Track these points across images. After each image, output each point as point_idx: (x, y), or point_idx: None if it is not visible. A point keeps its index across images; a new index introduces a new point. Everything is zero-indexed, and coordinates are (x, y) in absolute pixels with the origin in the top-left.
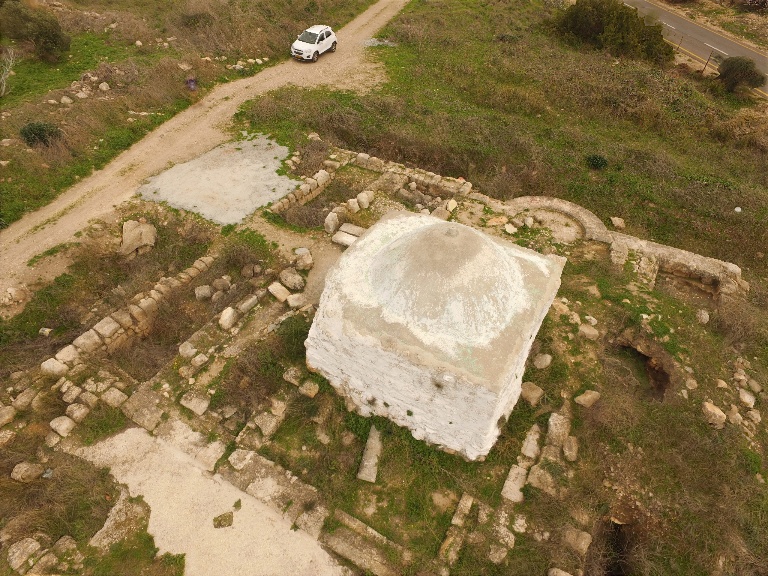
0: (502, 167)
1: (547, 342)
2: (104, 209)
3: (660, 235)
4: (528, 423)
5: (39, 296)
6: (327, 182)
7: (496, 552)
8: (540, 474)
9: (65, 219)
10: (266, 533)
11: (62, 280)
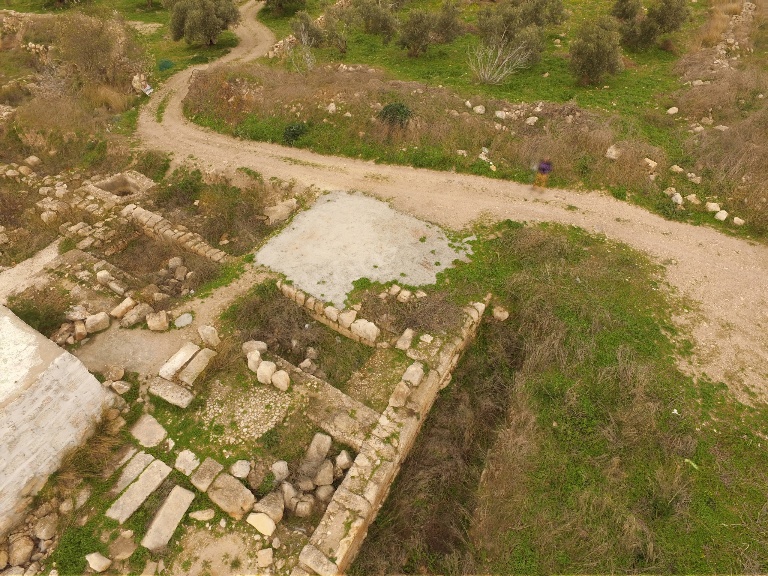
0: None
1: None
2: (308, 181)
3: None
4: None
5: None
6: (367, 340)
7: None
8: None
9: (297, 167)
10: None
11: (232, 190)
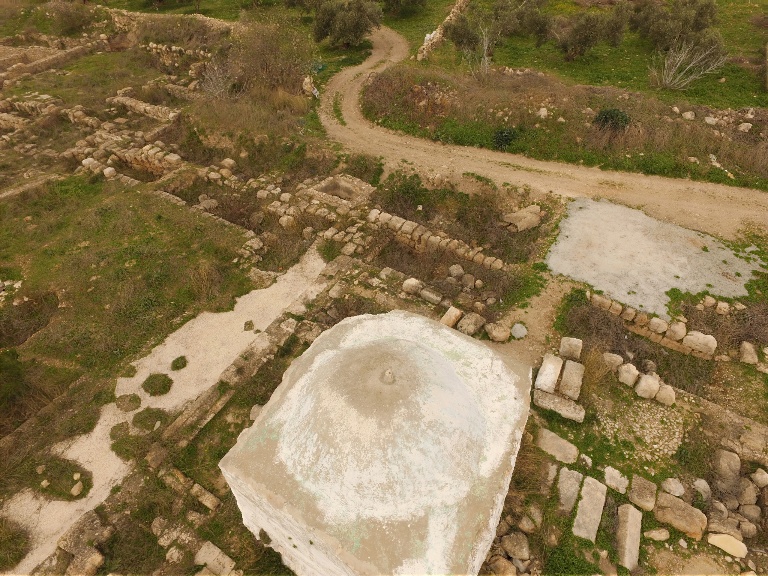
0: None
1: None
2: (544, 187)
3: None
4: None
5: (442, 191)
6: (702, 353)
7: (160, 524)
8: None
9: (523, 173)
10: (233, 350)
11: (461, 196)
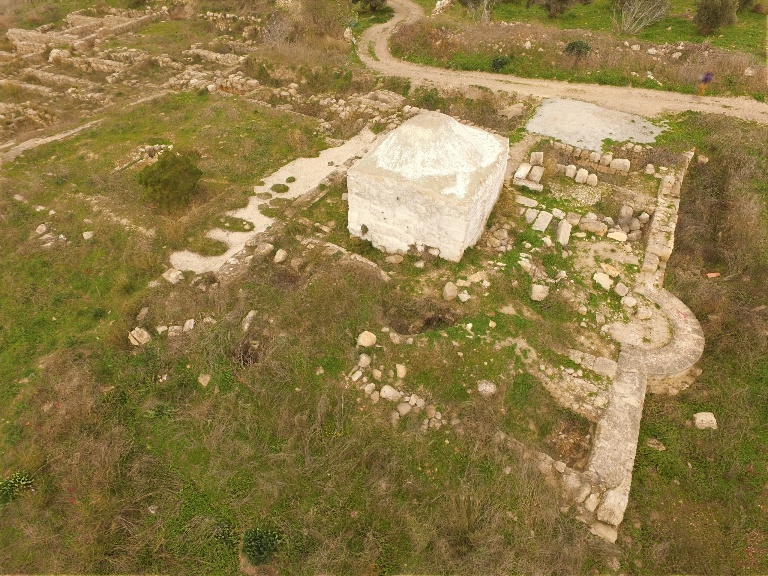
0: (763, 305)
1: (434, 262)
2: (527, 92)
3: (704, 475)
4: (372, 256)
5: (454, 98)
6: (622, 172)
7: (300, 237)
8: (334, 250)
9: (512, 85)
10: (323, 174)
11: (467, 100)
